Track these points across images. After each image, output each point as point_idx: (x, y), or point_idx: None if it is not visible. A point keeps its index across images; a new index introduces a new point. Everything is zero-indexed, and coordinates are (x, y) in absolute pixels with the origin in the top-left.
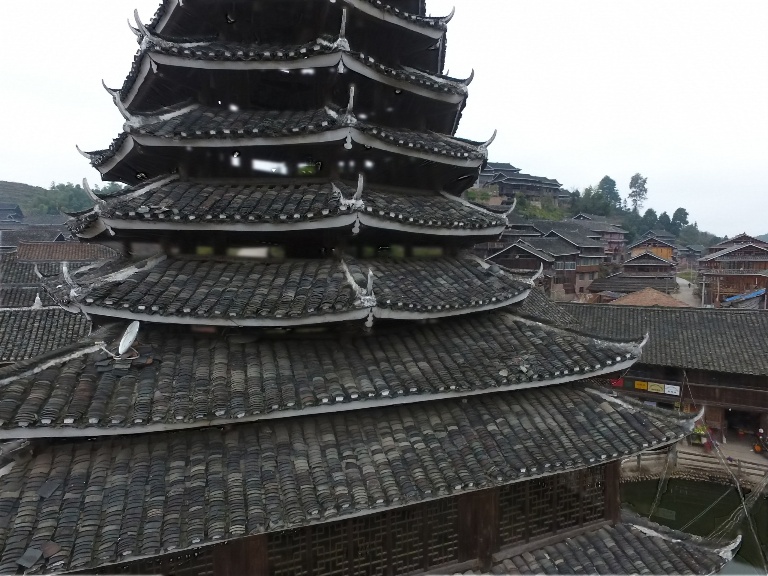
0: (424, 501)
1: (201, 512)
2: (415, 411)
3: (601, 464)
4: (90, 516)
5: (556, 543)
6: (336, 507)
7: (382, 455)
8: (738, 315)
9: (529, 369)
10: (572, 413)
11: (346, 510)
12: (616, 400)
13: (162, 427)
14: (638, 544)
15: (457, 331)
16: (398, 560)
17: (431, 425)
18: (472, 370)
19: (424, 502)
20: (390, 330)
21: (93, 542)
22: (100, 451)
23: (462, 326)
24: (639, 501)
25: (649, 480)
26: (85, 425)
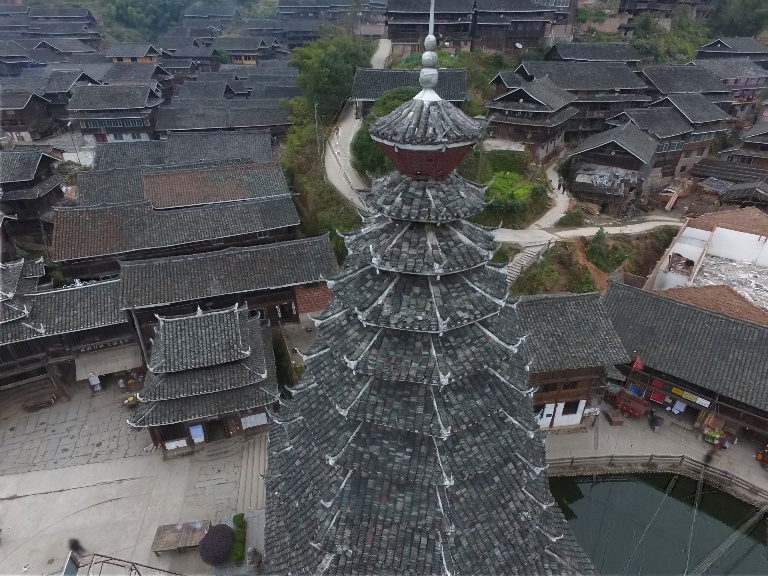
0: None
1: None
2: None
3: None
4: None
5: None
6: None
7: None
8: None
9: None
10: None
11: None
12: None
13: None
14: None
15: None
16: None
17: None
18: None
19: None
20: None
21: None
22: None
23: None
24: (642, 481)
25: (654, 473)
26: None
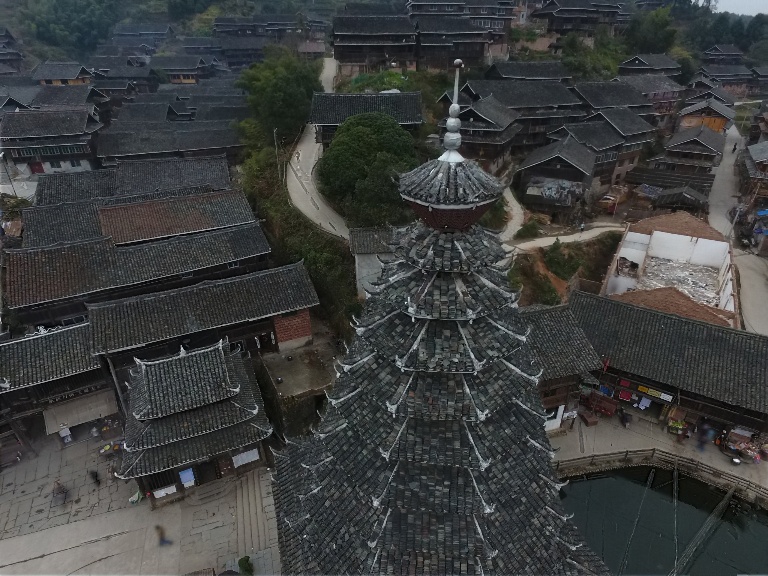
0: None
1: None
2: None
3: None
4: None
5: None
6: None
7: None
8: (741, 337)
9: None
10: None
11: None
12: None
13: None
14: None
15: None
16: None
17: None
18: None
19: None
20: None
21: None
22: None
23: None
24: (620, 476)
25: (630, 467)
26: None
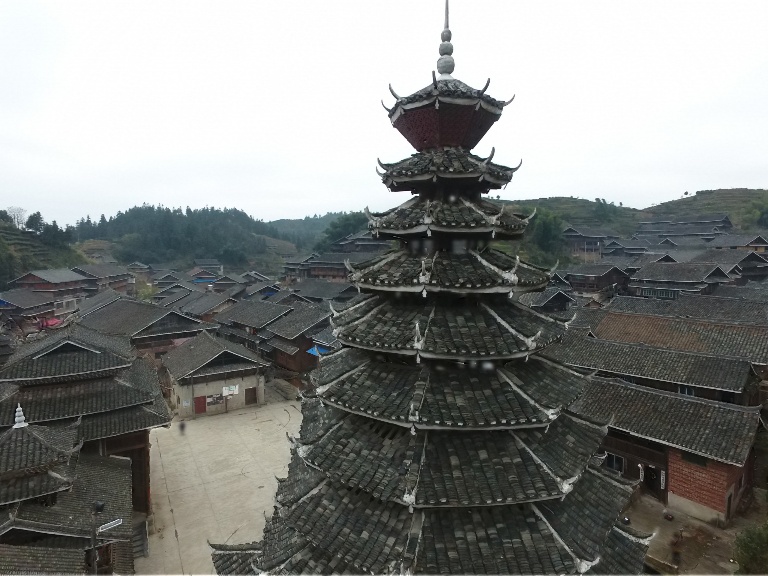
0: None
1: None
2: None
3: None
4: None
5: None
6: None
7: None
8: None
9: None
10: None
11: None
12: None
13: None
14: None
15: None
16: None
17: None
18: None
19: None
20: None
21: None
22: None
23: None
24: None
25: None
26: None
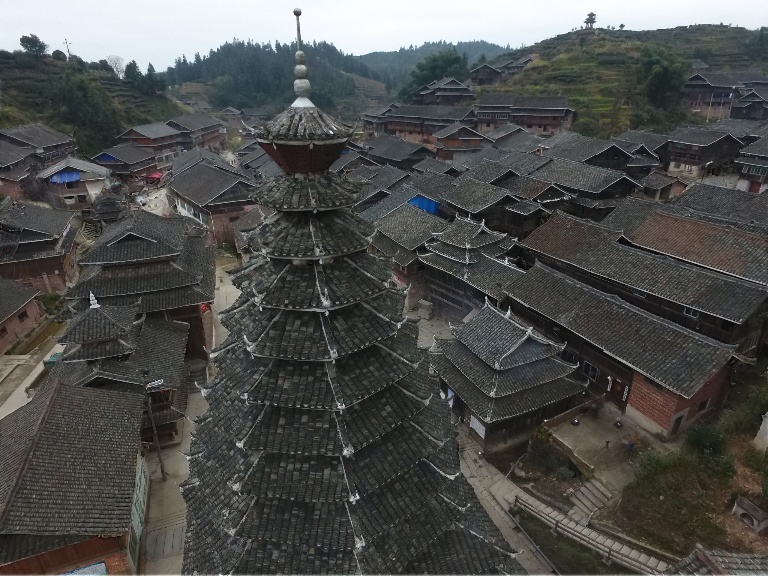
0: None
1: None
2: None
3: None
4: None
5: None
6: None
7: None
8: None
9: None
10: None
11: None
12: None
13: None
14: None
15: None
16: None
17: None
18: None
19: None
20: None
21: None
22: None
23: None
24: None
25: None
26: None
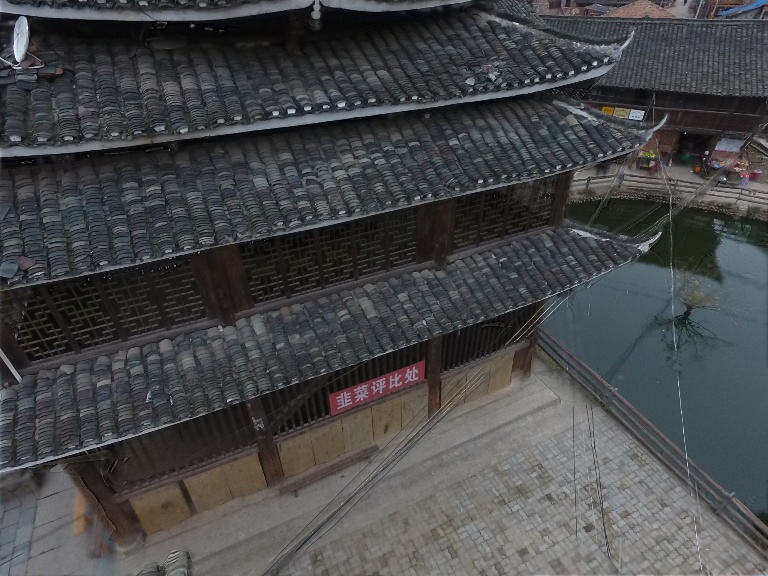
0: (385, 212)
1: (167, 227)
2: (375, 128)
3: (555, 175)
4: (54, 234)
5: (502, 246)
6: (300, 219)
7: (342, 171)
8: (730, 27)
9: (498, 77)
10: (536, 127)
11: (310, 221)
12: (582, 112)
13: (99, 145)
14: (573, 244)
15: (422, 34)
16: (363, 264)
17: (392, 141)
18: (436, 79)
19: (385, 213)
20: (344, 33)
21: (66, 256)
22: (41, 175)
23: (428, 28)
24: (580, 219)
25: (593, 201)
26: (8, 144)
